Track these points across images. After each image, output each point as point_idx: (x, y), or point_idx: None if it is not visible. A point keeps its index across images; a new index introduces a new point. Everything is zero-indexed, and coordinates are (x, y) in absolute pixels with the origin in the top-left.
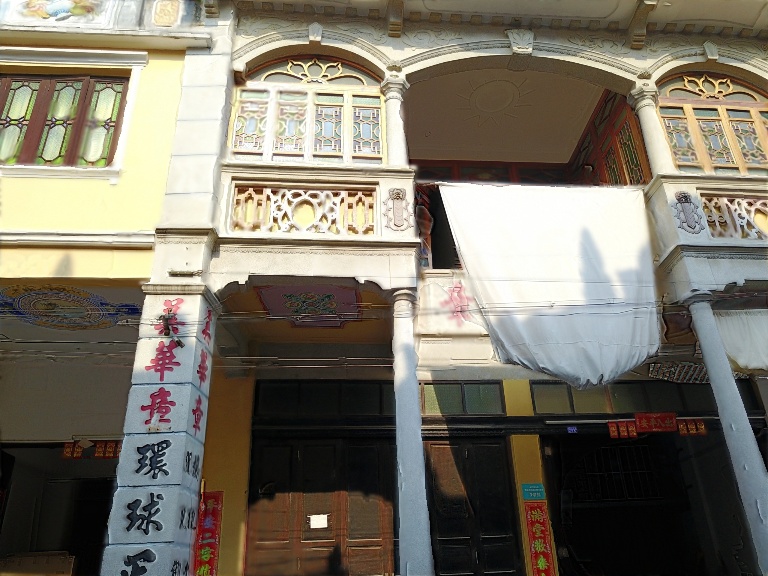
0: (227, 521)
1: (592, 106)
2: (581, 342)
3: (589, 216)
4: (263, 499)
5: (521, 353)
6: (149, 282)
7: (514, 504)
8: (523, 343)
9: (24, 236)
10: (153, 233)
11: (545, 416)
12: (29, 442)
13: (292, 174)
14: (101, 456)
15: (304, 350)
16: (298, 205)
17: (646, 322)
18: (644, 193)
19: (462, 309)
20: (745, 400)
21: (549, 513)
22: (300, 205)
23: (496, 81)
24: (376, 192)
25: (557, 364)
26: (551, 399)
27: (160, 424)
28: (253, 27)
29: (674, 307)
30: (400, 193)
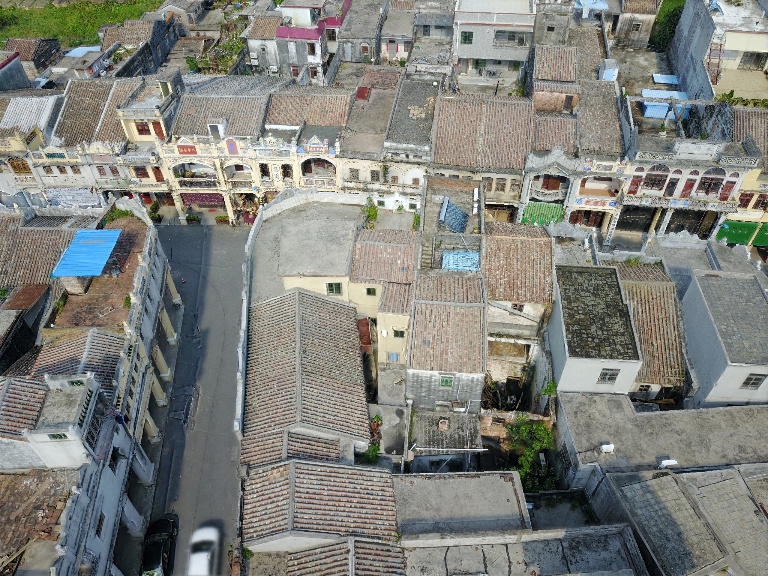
0: None
1: None
2: None
3: None
4: None
5: None
6: None
7: None
8: None
9: None
10: None
11: None
12: None
13: None
14: None
15: None
16: None
17: None
18: None
19: None
20: None
21: None
22: None
23: None
24: None
25: (8, 193)
26: None
27: None
28: None
29: None
30: None
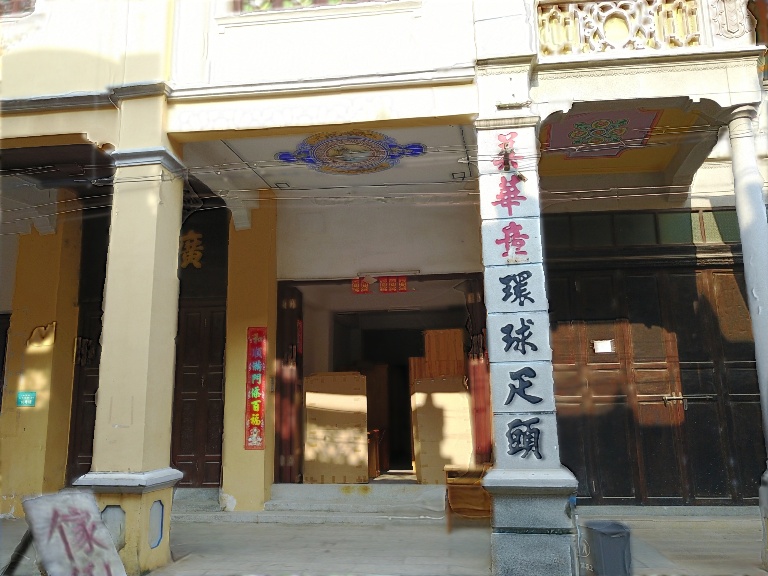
0: None
1: None
2: None
3: None
4: None
5: None
6: (480, 117)
7: None
8: None
9: (347, 80)
10: (472, 65)
11: None
12: (320, 280)
13: None
14: (383, 291)
15: (574, 182)
16: (608, 20)
17: None
18: None
19: None
20: None
21: None
22: (610, 19)
23: None
24: None
25: None
26: None
27: (517, 256)
28: None
29: None
30: None
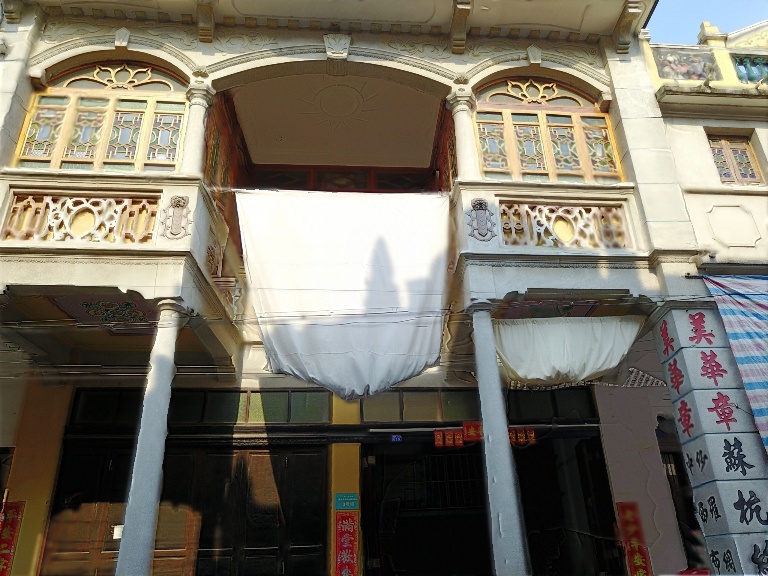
0: (25, 532)
1: (437, 110)
2: (351, 352)
3: (388, 223)
4: (68, 509)
5: (293, 363)
6: None
7: (327, 514)
8: (295, 353)
9: None
10: None
11: (370, 424)
12: None
13: (72, 182)
14: None
15: (127, 358)
16: (79, 213)
17: (429, 331)
18: (450, 200)
19: (236, 318)
20: (583, 407)
21: (363, 523)
22: (82, 213)
23: (335, 86)
24: (160, 200)
25: (325, 374)
26: (380, 407)
27: None
28: (59, 32)
29: (459, 316)
30: (181, 201)
